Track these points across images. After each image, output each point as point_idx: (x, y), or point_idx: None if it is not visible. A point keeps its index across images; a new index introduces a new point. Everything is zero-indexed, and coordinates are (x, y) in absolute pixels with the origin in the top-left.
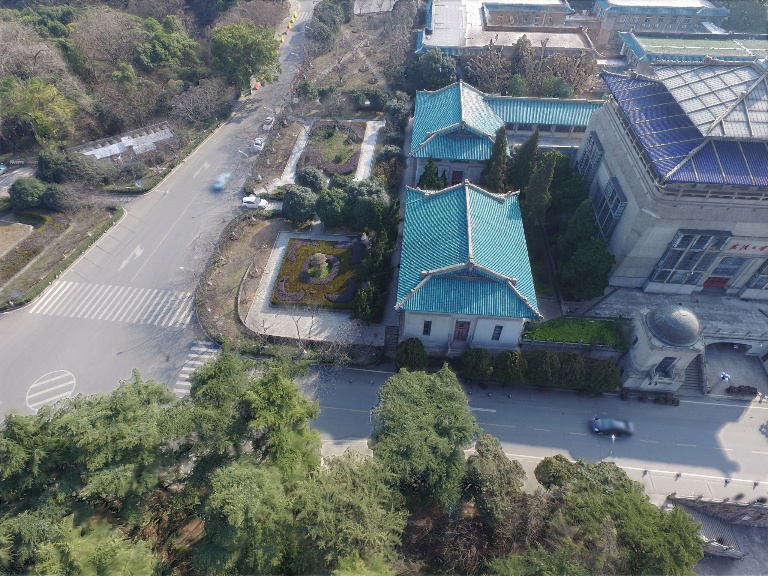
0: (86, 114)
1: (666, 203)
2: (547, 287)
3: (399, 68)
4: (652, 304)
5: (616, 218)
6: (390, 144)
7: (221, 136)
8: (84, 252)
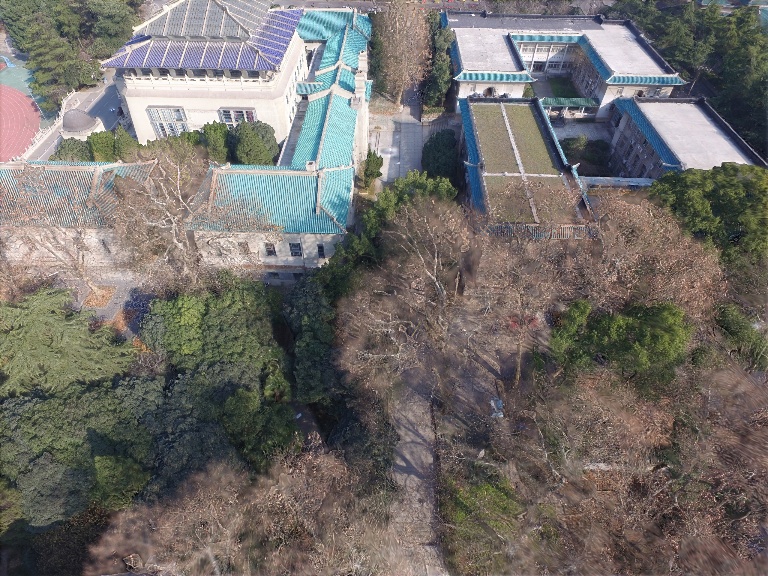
0: None
1: None
2: None
3: None
4: None
5: None
6: None
7: (361, 3)
8: None
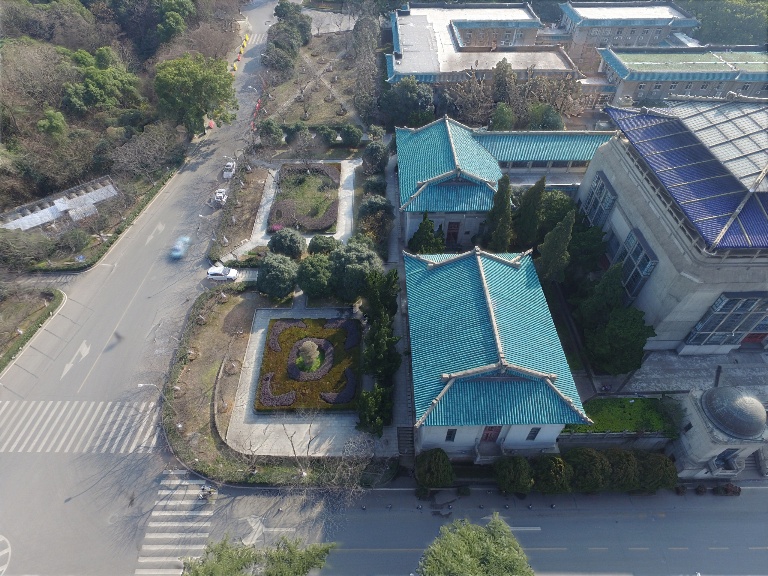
0: (8, 175)
1: (709, 266)
2: (574, 359)
3: (371, 99)
4: (690, 370)
5: (645, 277)
6: (372, 190)
7: (175, 188)
8: (14, 357)
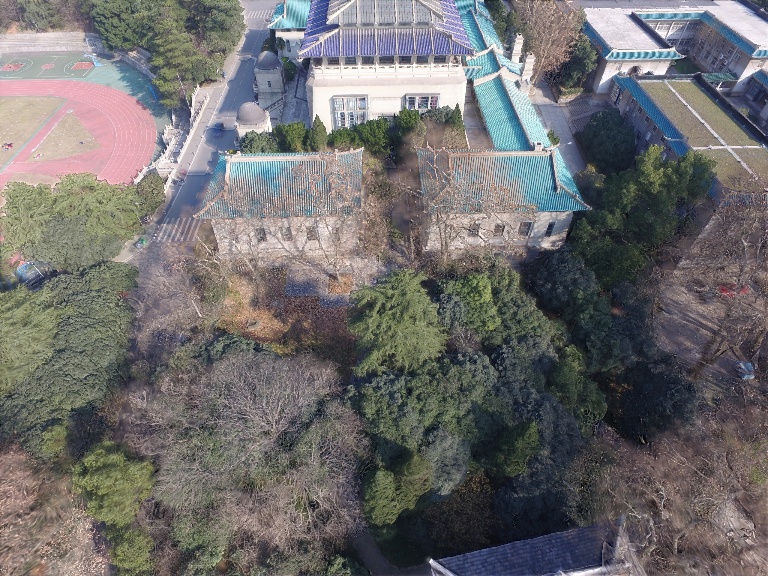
0: None
1: None
2: None
3: None
4: None
5: None
6: None
7: None
8: None
